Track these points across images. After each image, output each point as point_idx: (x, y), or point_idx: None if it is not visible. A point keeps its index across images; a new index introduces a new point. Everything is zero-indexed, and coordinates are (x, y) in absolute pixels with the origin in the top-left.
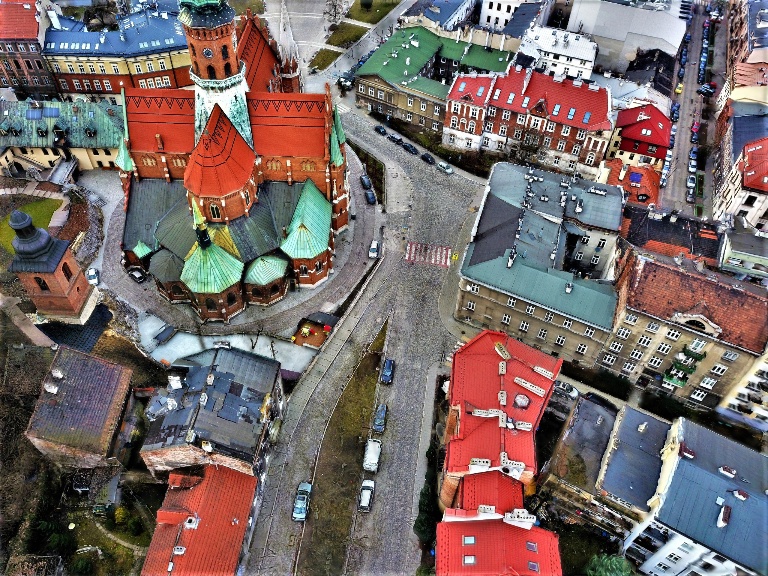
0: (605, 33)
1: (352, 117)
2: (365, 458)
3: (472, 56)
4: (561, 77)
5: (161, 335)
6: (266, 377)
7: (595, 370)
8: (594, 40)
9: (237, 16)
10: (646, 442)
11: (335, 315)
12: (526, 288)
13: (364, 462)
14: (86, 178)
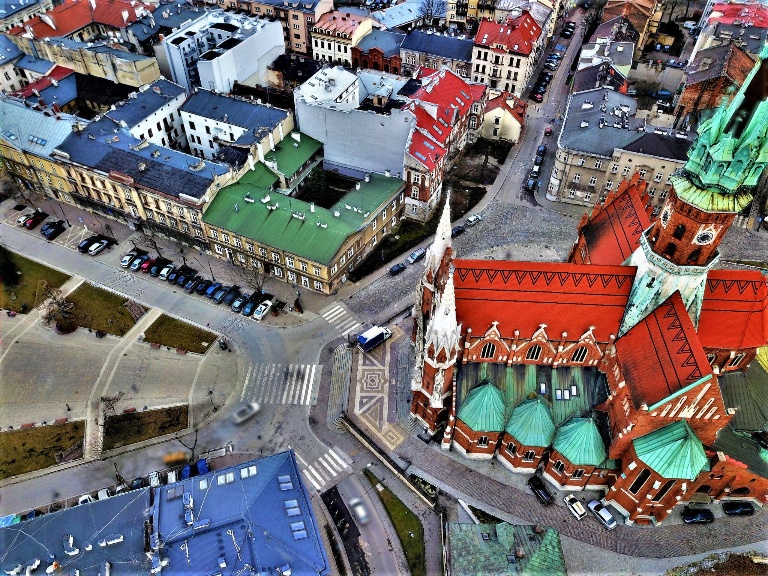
0: (245, 75)
1: (359, 299)
2: None
3: (281, 165)
4: (432, 86)
5: None
6: None
7: None
8: (329, 66)
9: None
10: None
11: None
12: None
13: None
14: None
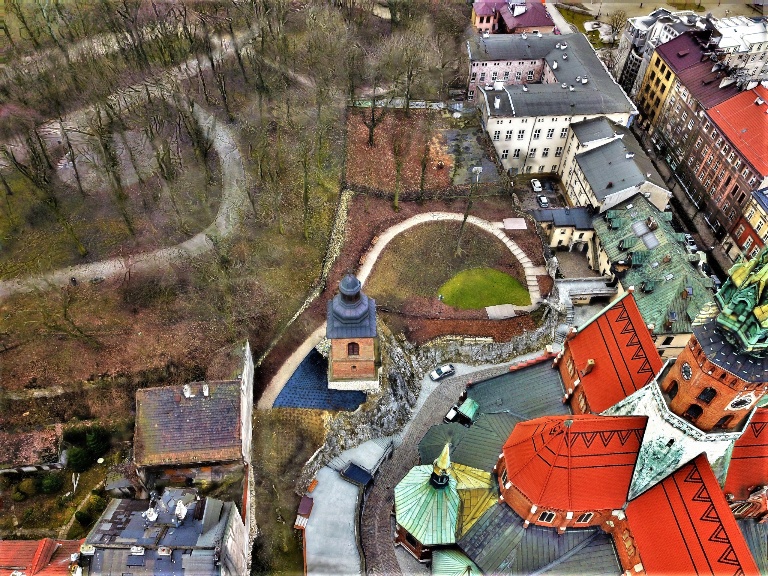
0: None
1: None
2: None
3: None
4: None
5: (355, 469)
6: None
7: None
8: None
9: None
10: None
11: None
12: None
13: None
14: None
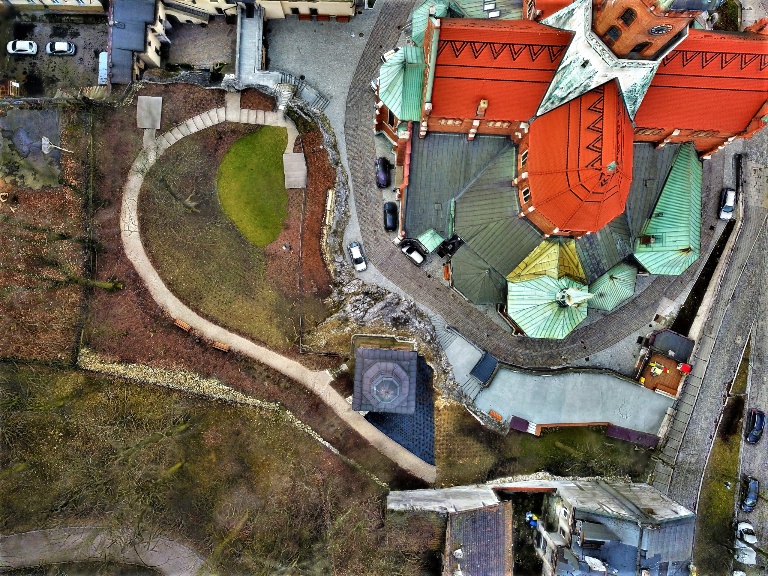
0: None
1: None
2: (744, 558)
3: None
4: None
5: (478, 370)
6: (686, 540)
7: None
8: None
9: None
10: None
11: (677, 322)
12: None
13: (740, 559)
14: (279, 39)
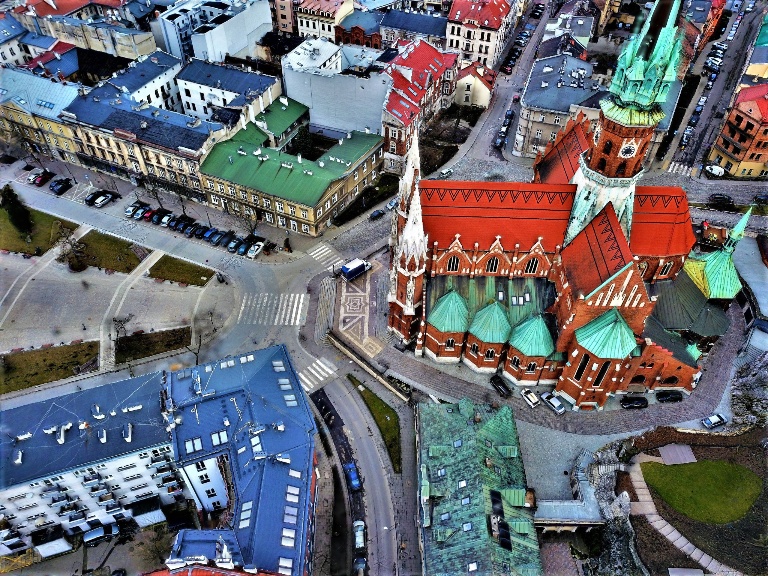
0: (236, 49)
1: (343, 240)
2: None
3: (270, 126)
4: (407, 53)
5: None
6: None
7: (674, 115)
8: None
9: None
10: (763, 81)
11: None
12: (668, 104)
13: None
14: None
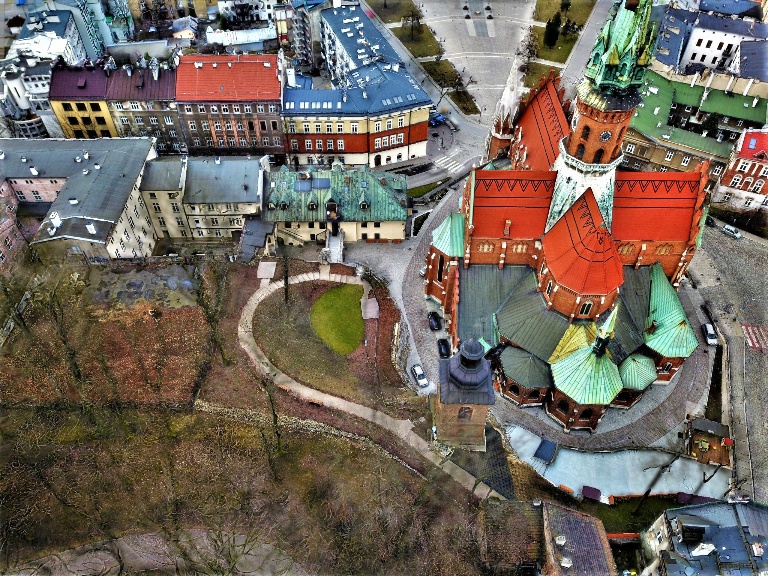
0: None
1: None
2: None
3: (712, 102)
4: None
5: (541, 452)
6: None
7: None
8: None
9: (418, 58)
10: None
11: None
12: None
13: None
14: (353, 252)
